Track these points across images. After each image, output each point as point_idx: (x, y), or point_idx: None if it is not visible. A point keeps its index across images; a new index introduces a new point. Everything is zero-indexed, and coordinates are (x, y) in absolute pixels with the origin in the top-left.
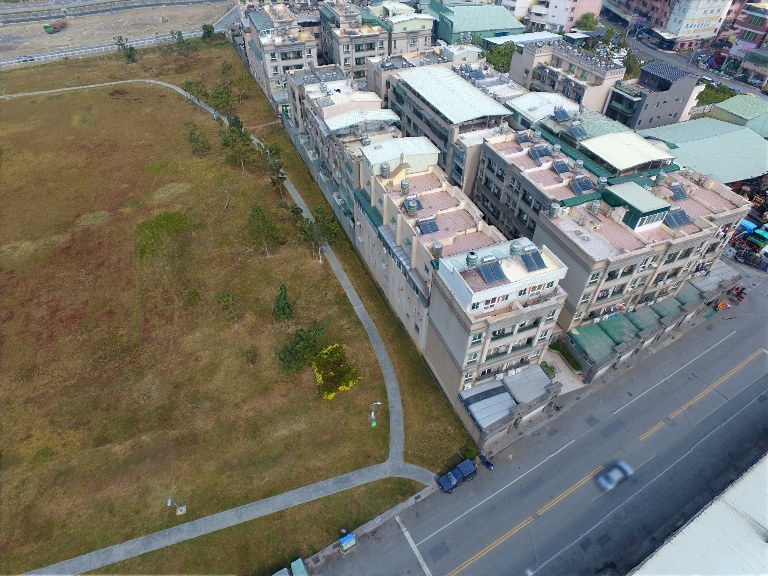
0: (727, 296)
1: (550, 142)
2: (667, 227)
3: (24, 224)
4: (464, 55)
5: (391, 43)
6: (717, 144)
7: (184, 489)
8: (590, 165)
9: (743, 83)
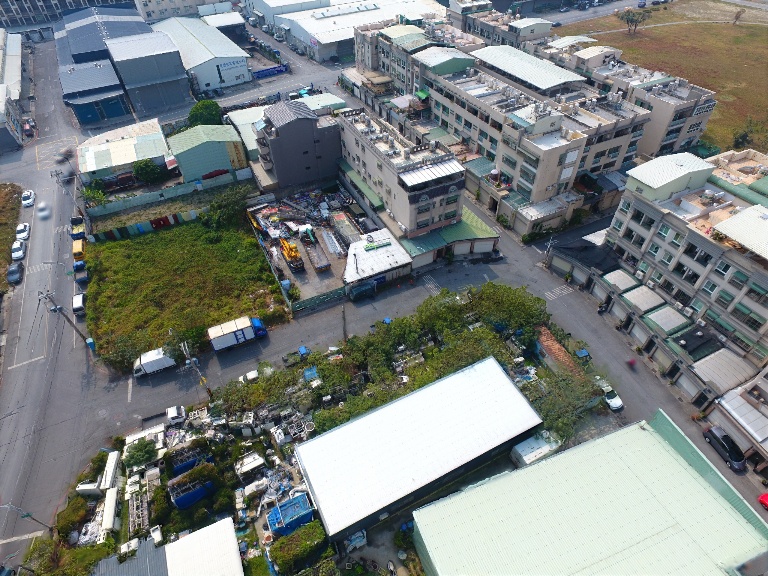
0: None
1: None
2: None
3: (762, 93)
4: None
5: None
6: None
7: None
8: None
9: (4, 315)
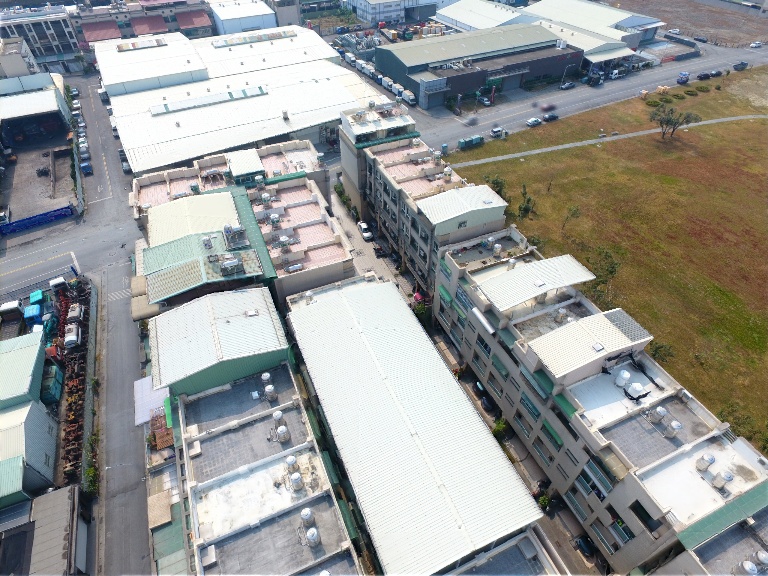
0: None
1: None
2: None
3: None
4: None
5: None
6: None
7: (527, 165)
8: (248, 209)
9: None
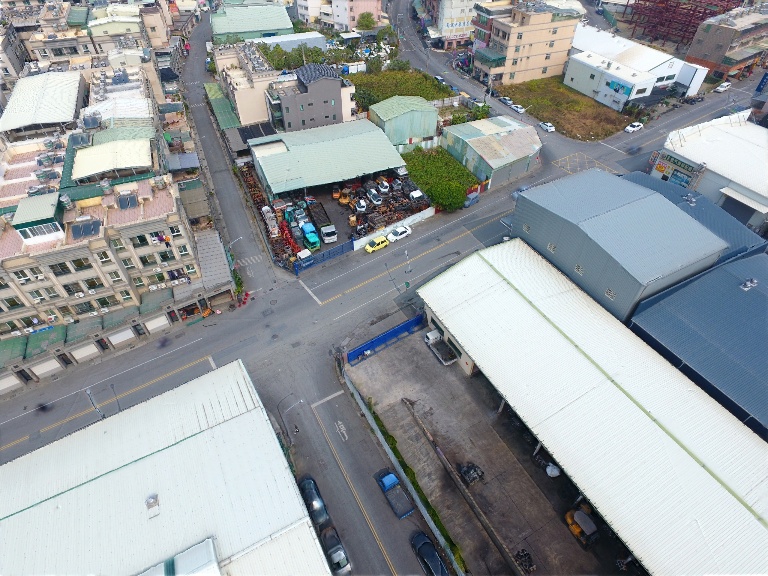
0: (230, 302)
1: (66, 150)
2: (63, 238)
3: None
4: (121, 59)
5: (96, 47)
6: (336, 146)
7: None
8: (64, 174)
9: (477, 82)
